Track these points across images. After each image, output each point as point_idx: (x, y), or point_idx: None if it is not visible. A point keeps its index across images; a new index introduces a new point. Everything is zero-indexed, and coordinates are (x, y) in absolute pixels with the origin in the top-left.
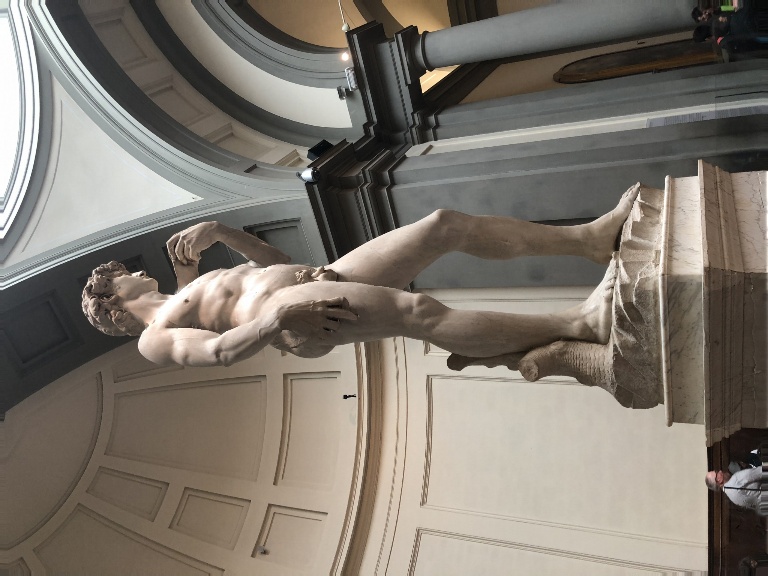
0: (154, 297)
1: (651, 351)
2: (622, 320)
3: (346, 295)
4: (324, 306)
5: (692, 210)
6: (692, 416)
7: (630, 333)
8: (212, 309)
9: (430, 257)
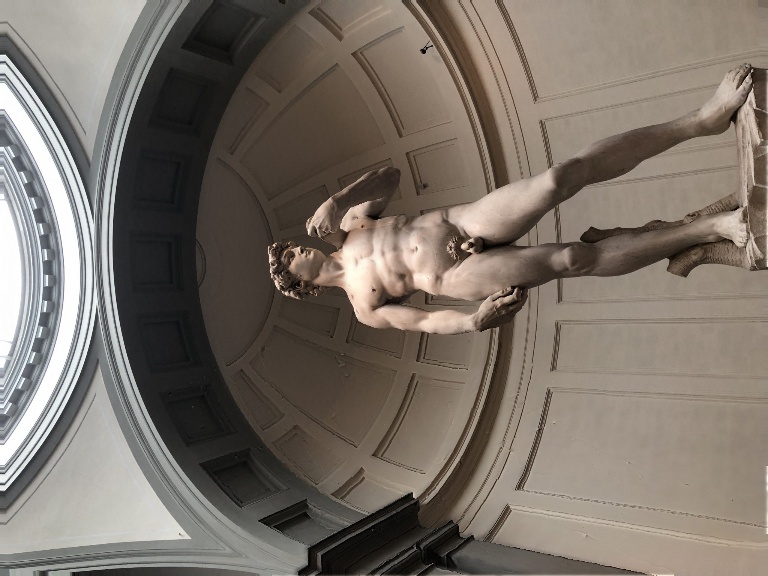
0: (331, 270)
1: None
2: None
3: (510, 278)
4: (505, 308)
5: None
6: None
7: None
8: (397, 289)
9: None
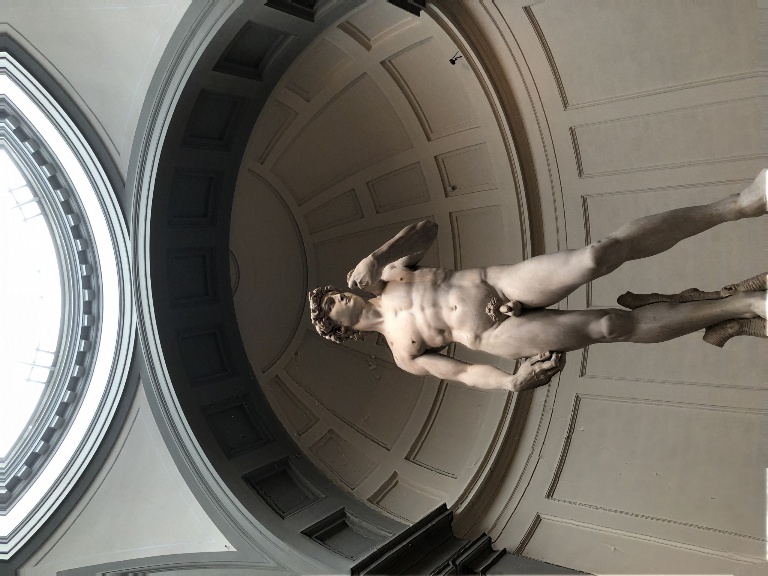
0: (370, 318)
1: None
2: None
3: (548, 344)
4: (543, 372)
5: None
6: None
7: None
8: (436, 342)
9: None
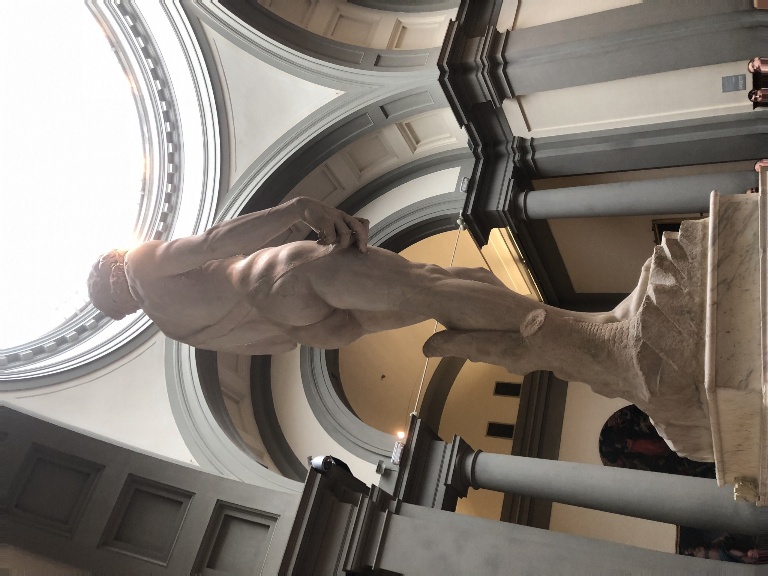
0: None
1: (693, 294)
2: (662, 259)
3: None
4: None
5: None
6: (744, 376)
7: (669, 273)
8: None
9: None
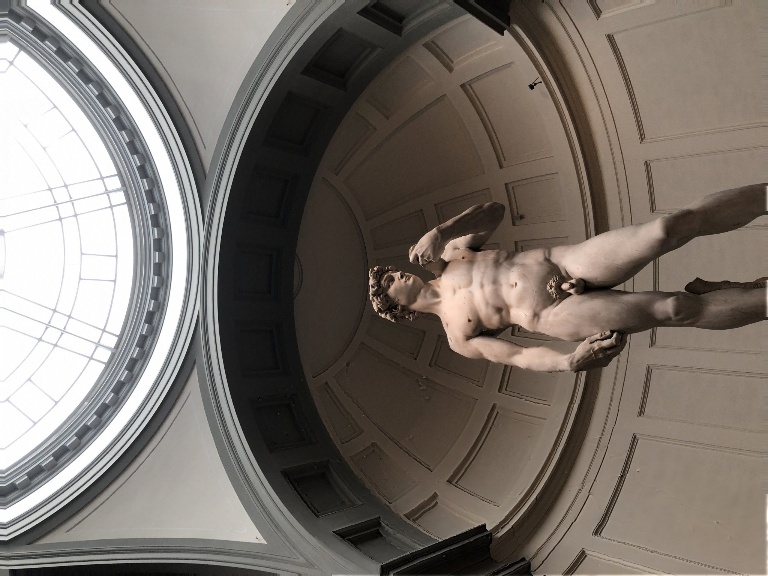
0: (428, 297)
1: None
2: None
3: (610, 322)
4: (603, 351)
5: None
6: None
7: None
8: (493, 322)
9: None
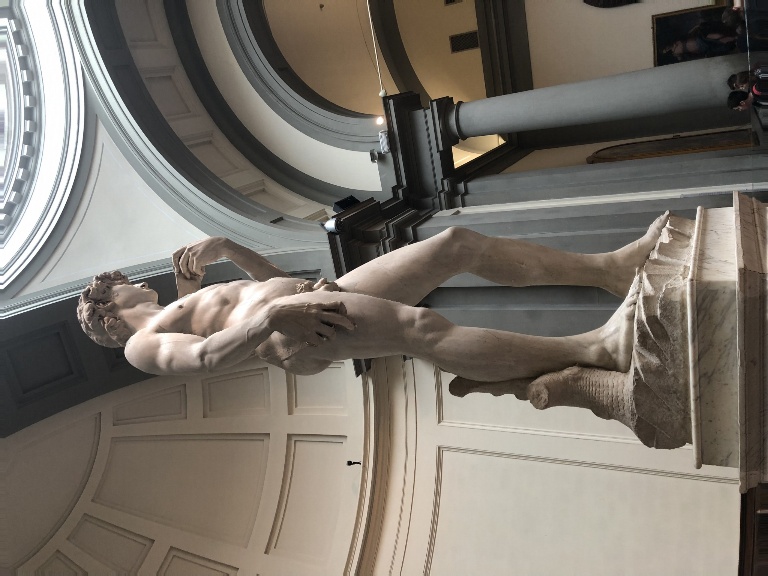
0: (151, 307)
1: (677, 375)
2: (644, 337)
3: (345, 303)
4: (319, 309)
5: (726, 232)
6: (724, 457)
7: (653, 353)
8: (206, 316)
9: (439, 275)
